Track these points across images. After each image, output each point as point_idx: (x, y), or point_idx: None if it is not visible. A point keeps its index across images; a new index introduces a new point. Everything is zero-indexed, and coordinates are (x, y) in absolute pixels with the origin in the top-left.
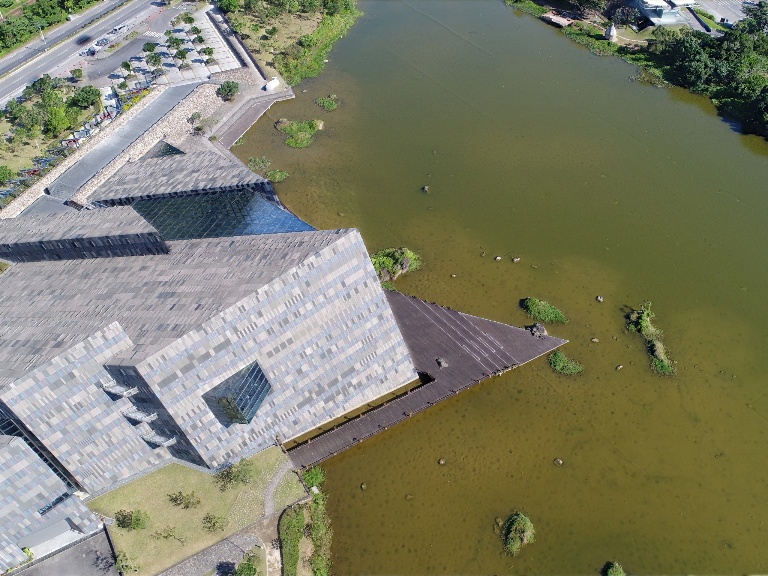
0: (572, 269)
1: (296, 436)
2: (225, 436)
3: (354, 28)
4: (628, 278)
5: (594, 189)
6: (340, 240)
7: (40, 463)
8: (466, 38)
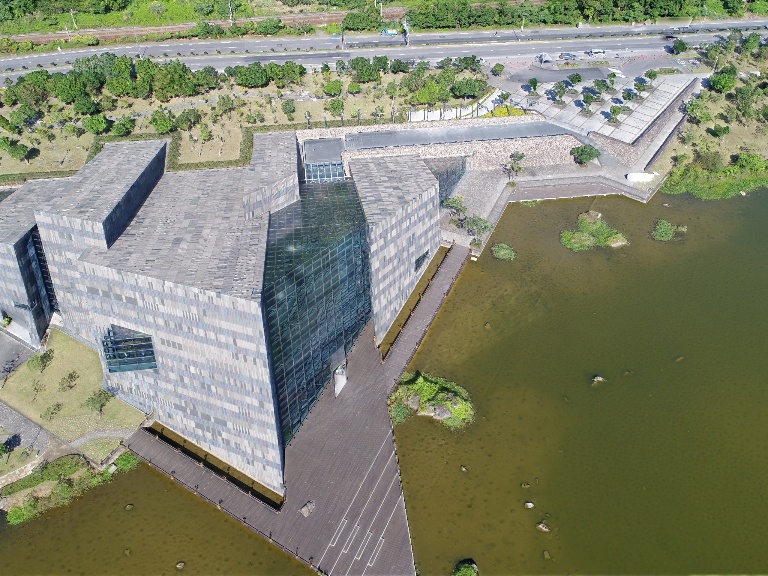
0: None
1: (168, 427)
2: None
3: None
4: None
5: None
6: (242, 299)
7: (19, 272)
8: None
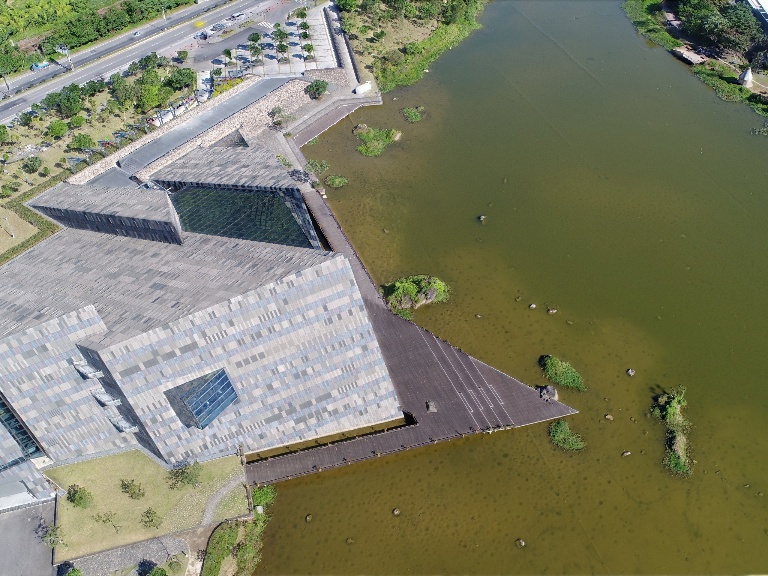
0: (611, 333)
1: (261, 450)
2: (185, 435)
3: (467, 40)
4: (672, 355)
5: (667, 248)
6: (325, 263)
7: None
8: (581, 64)
